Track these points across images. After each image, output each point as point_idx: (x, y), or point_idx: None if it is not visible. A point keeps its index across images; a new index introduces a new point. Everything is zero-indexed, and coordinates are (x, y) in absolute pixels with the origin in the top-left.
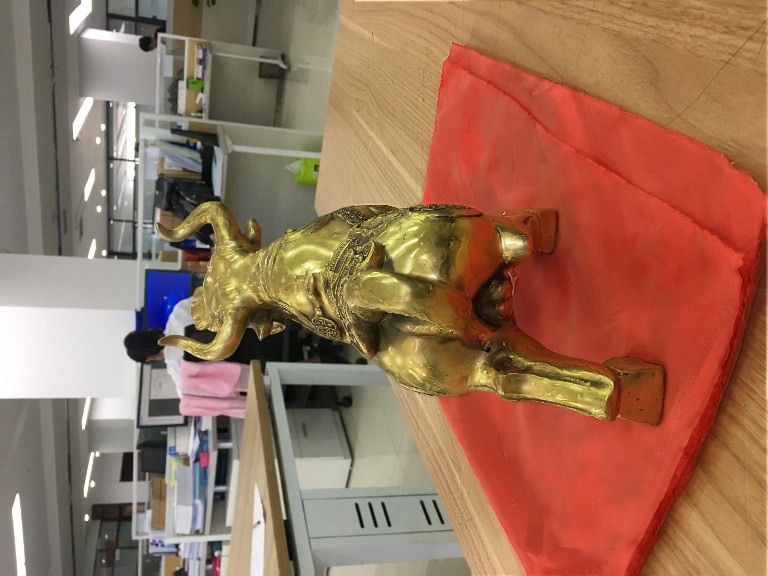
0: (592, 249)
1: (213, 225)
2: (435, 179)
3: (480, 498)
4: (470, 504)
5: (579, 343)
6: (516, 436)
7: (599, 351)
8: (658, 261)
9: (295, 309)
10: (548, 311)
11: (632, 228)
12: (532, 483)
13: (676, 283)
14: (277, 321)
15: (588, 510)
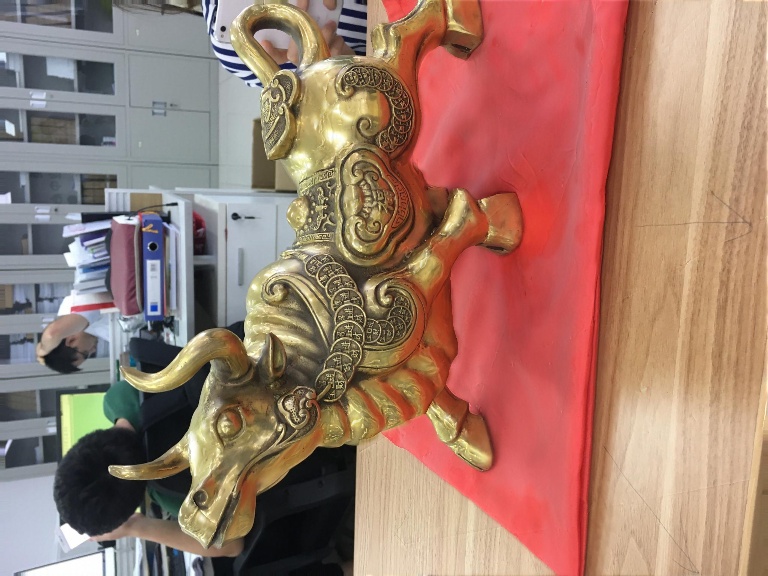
0: (435, 139)
1: (185, 437)
2: (441, 454)
3: (665, 185)
4: (694, 209)
5: (469, 106)
6: (561, 150)
7: (468, 84)
8: (428, 74)
9: (281, 273)
10: (473, 169)
11: (423, 110)
12: (576, 87)
13: (432, 53)
14: (298, 386)
15: (550, 1)
